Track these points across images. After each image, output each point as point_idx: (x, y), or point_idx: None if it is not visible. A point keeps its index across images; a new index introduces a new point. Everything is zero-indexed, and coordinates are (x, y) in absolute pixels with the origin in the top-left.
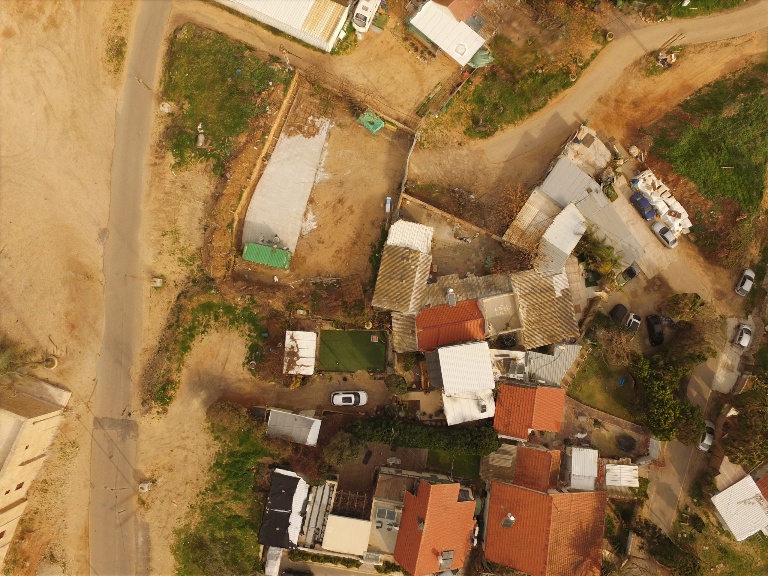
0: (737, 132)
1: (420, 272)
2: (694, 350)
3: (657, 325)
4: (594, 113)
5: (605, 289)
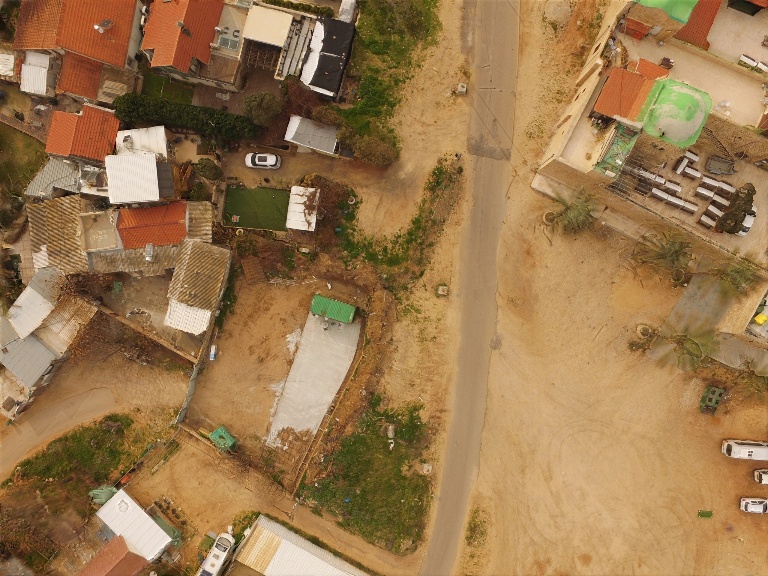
0: None
1: (180, 281)
2: None
3: None
4: (1, 432)
5: None
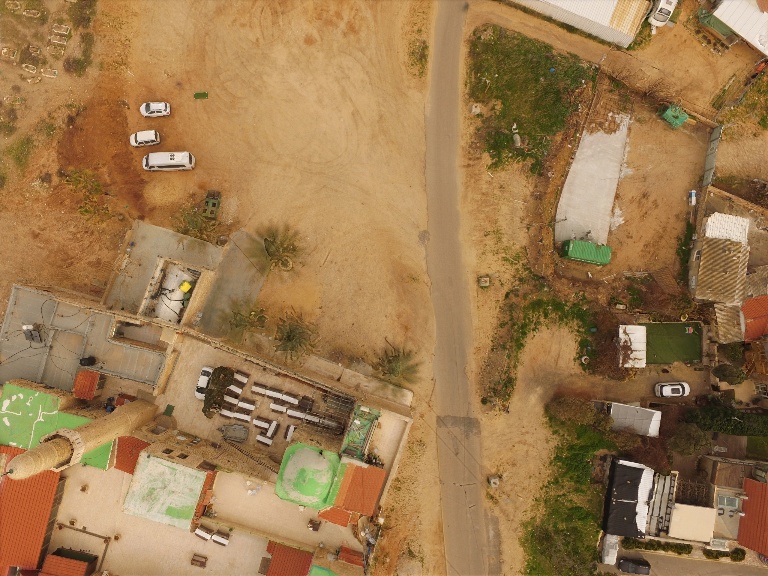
0: None
1: (740, 263)
2: None
3: None
4: None
5: None
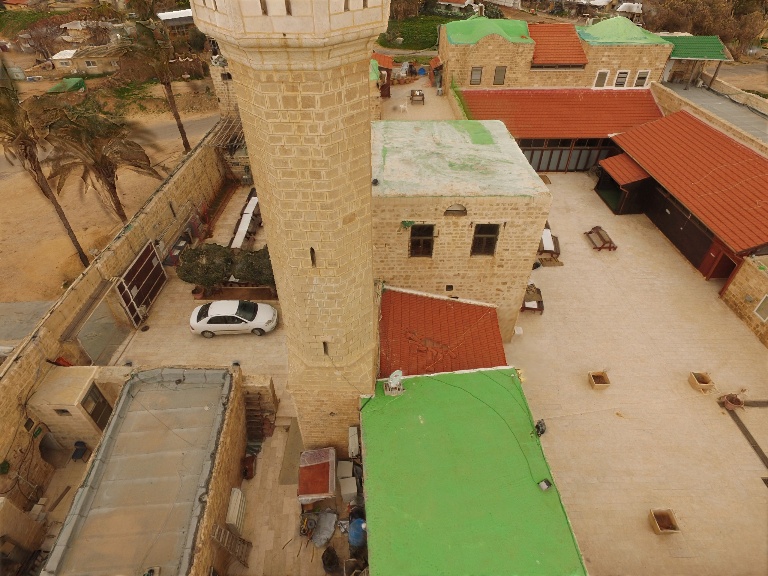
0: None
1: None
2: None
3: None
4: None
5: None
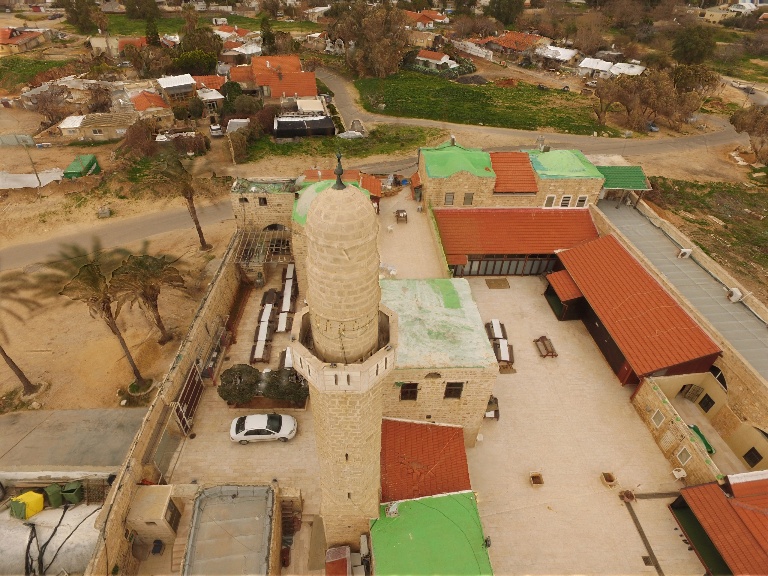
0: None
1: None
2: None
3: None
4: None
5: None
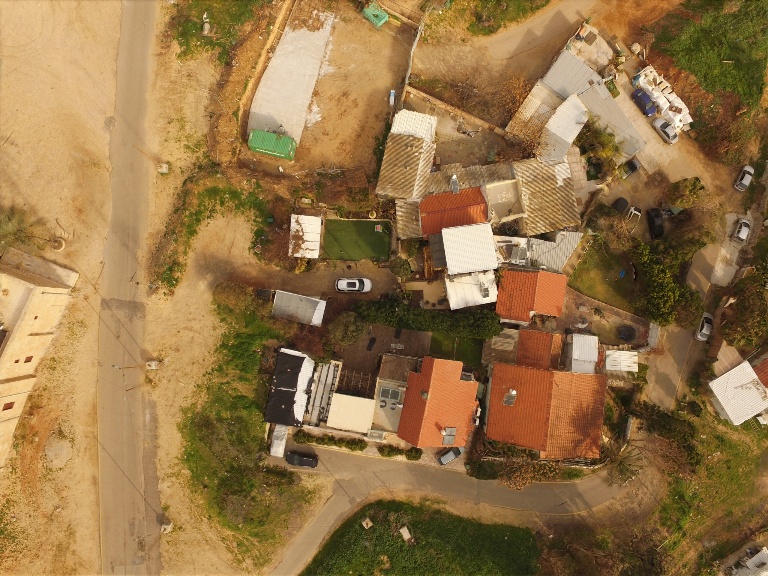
0: (738, 27)
1: (424, 160)
2: (694, 235)
3: (657, 219)
4: (596, 12)
5: (606, 180)
